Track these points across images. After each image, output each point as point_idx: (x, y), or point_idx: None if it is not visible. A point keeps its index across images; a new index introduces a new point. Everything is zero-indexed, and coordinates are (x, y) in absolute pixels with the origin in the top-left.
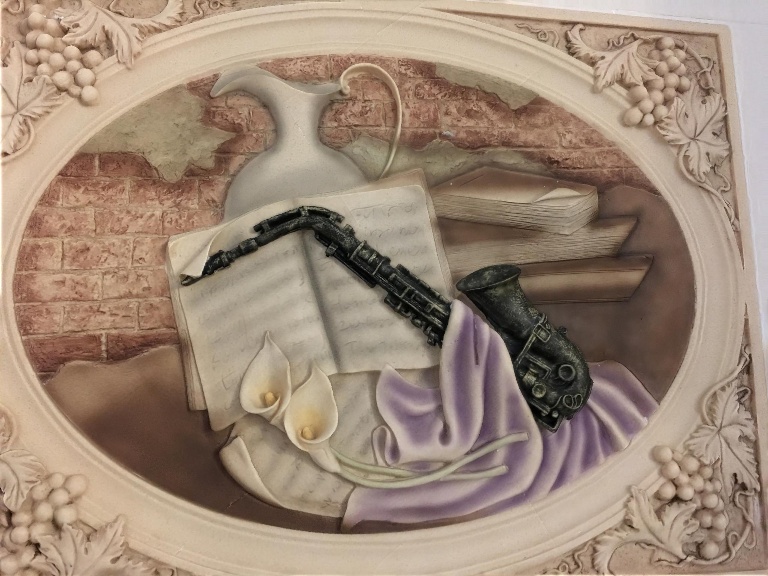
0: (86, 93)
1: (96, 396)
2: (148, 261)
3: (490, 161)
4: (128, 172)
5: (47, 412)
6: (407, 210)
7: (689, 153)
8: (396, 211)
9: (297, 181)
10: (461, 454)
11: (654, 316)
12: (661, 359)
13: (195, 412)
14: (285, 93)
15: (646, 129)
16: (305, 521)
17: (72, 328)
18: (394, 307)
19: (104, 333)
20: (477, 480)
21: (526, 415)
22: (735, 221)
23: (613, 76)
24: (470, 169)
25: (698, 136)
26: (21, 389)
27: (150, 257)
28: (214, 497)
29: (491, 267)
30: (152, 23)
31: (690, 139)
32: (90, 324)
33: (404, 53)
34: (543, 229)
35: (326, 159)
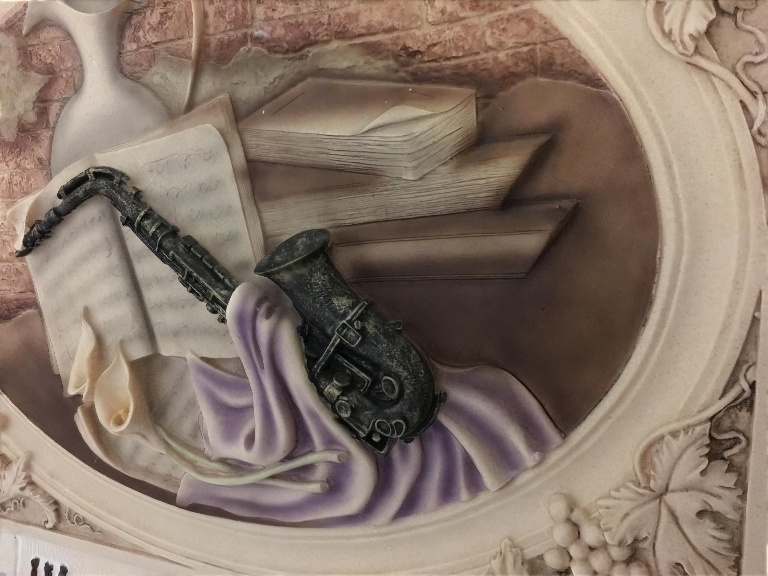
0: None
1: None
2: (7, 226)
3: (315, 68)
4: None
5: None
6: (206, 158)
7: None
8: (194, 161)
9: (96, 131)
10: (273, 461)
11: (571, 303)
12: (577, 371)
13: (56, 375)
14: (72, 19)
15: None
16: (152, 489)
17: None
18: None
19: None
20: (298, 490)
21: (336, 434)
22: (764, 128)
23: None
24: (290, 85)
25: None
26: None
27: (8, 222)
28: (82, 452)
29: (306, 232)
30: None
31: None
32: None
33: None
34: (380, 172)
35: (122, 98)
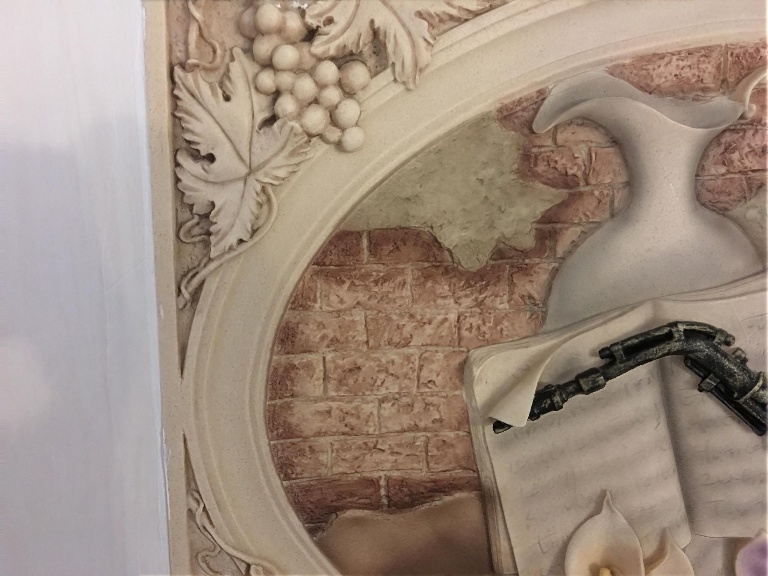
0: (350, 140)
1: (378, 552)
2: (440, 385)
3: None
4: (410, 256)
5: (318, 566)
6: None
7: None
8: None
9: (661, 273)
10: None
11: None
12: None
13: (501, 575)
14: (657, 129)
15: None
16: None
17: (343, 470)
18: None
19: (383, 475)
20: None
21: None
22: None
23: None
24: None
25: None
26: (285, 539)
27: (442, 379)
28: None
29: None
30: (448, 8)
31: None
32: (365, 464)
33: None
34: None
35: (707, 234)
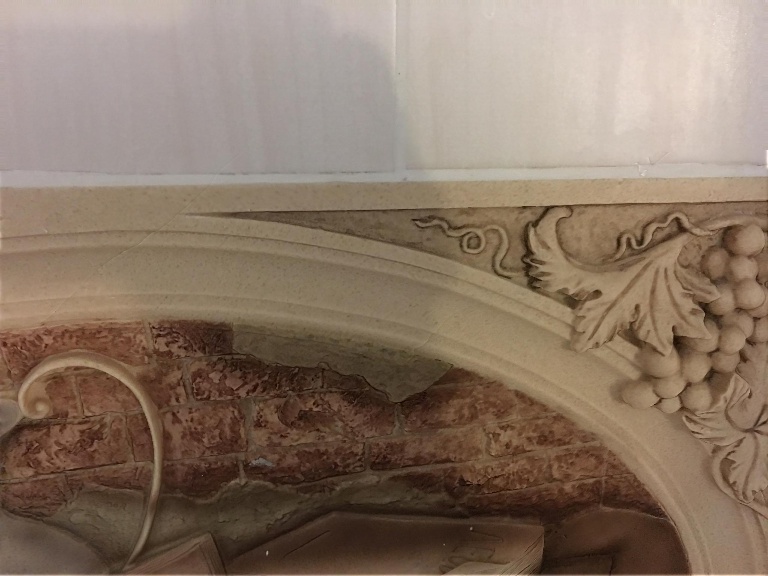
0: None
1: None
2: None
3: (344, 503)
4: None
5: None
6: None
7: (735, 457)
8: None
9: None
10: None
11: None
12: None
13: None
14: None
15: None
16: None
17: None
18: None
19: None
20: None
21: None
22: None
23: (613, 328)
24: (305, 519)
25: (762, 425)
26: None
27: None
28: None
29: None
30: None
31: (744, 432)
32: None
33: (161, 311)
34: None
35: (14, 550)
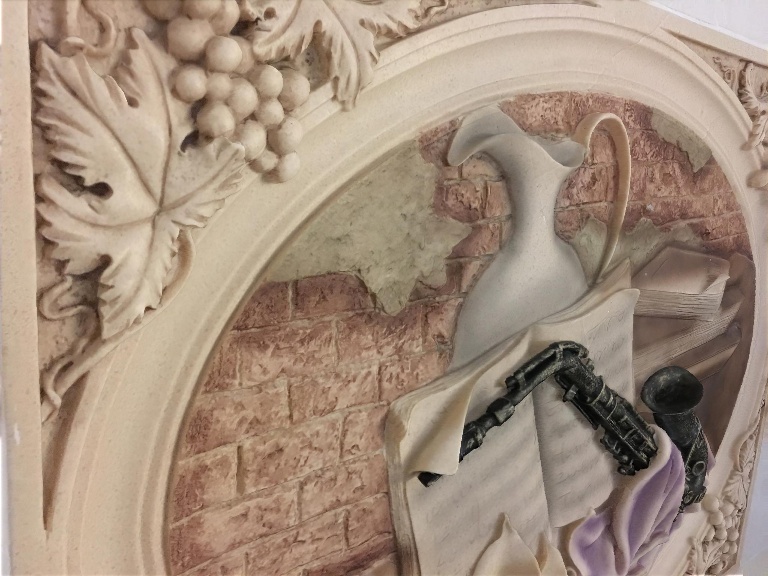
0: (289, 169)
1: None
2: (363, 448)
3: (673, 240)
4: (336, 306)
5: None
6: (620, 319)
7: None
8: (613, 322)
9: (538, 299)
10: None
11: (727, 381)
12: (722, 419)
13: None
14: (541, 166)
15: (762, 191)
16: None
17: None
18: (610, 447)
19: (302, 570)
20: None
21: None
22: None
23: None
24: (658, 252)
25: None
26: None
27: (365, 441)
28: None
29: (665, 371)
30: (389, 21)
31: None
32: (284, 565)
33: (632, 92)
34: (698, 318)
35: (563, 261)
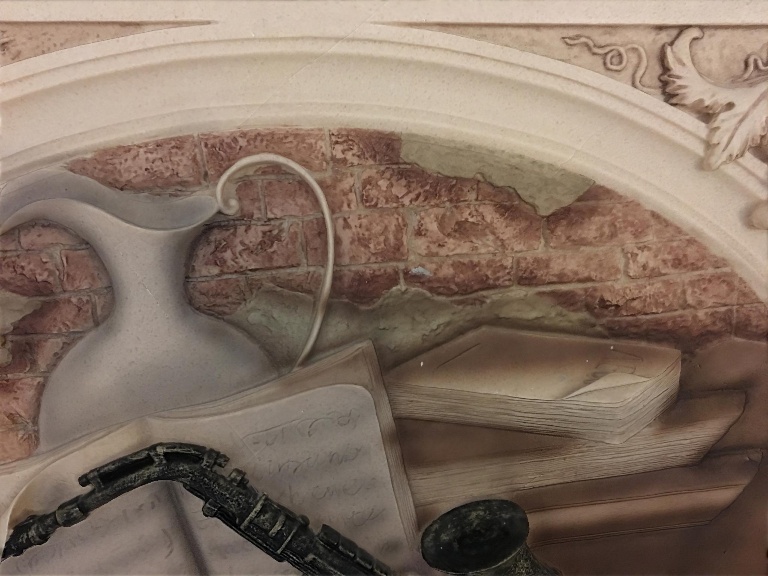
0: None
1: None
2: None
3: (494, 316)
4: None
5: None
6: (342, 422)
7: None
8: (323, 426)
9: (150, 387)
10: None
11: (746, 542)
12: None
13: None
14: (114, 232)
15: None
16: None
17: None
18: None
19: None
20: None
21: None
22: None
23: (744, 141)
24: (457, 333)
25: None
26: None
27: None
28: None
29: (482, 504)
30: None
31: None
32: None
33: (341, 118)
34: (577, 435)
35: (199, 343)
